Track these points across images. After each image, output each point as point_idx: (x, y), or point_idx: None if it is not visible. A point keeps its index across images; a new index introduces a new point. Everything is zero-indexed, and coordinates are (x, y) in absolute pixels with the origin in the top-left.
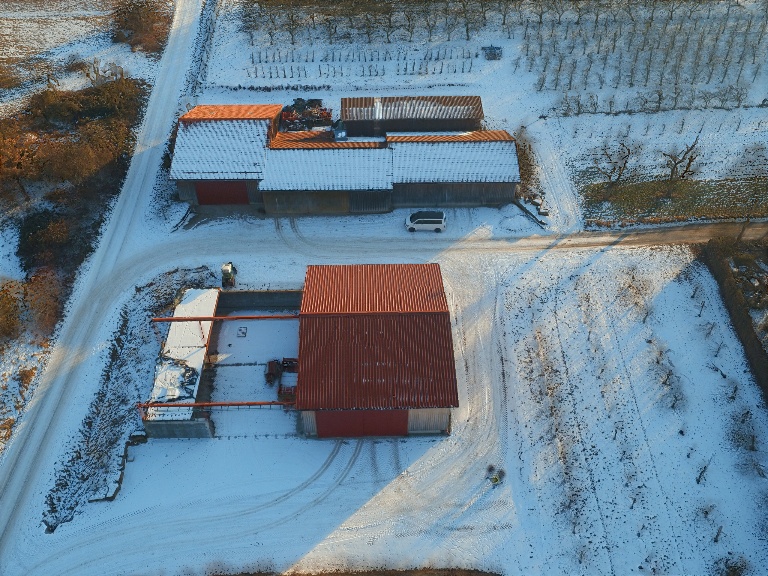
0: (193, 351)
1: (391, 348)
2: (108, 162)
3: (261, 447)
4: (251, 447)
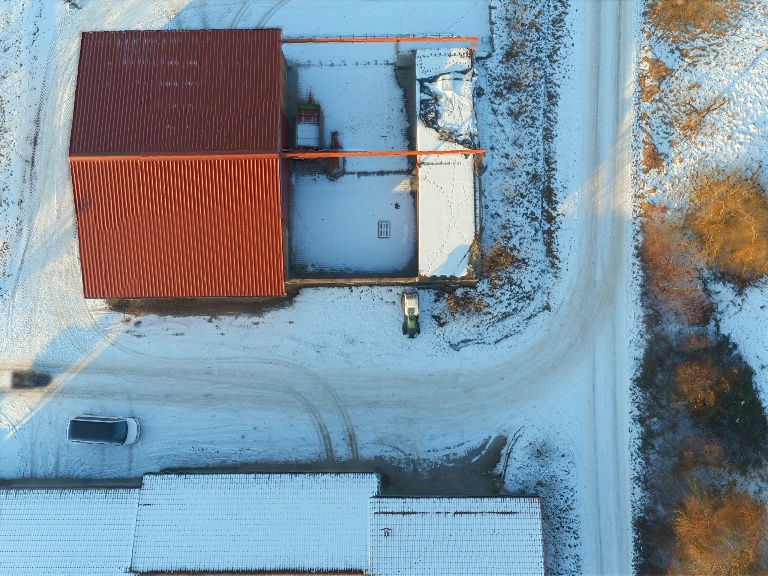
0: (434, 156)
1: (157, 105)
2: (669, 571)
3: (337, 50)
4: (349, 49)
